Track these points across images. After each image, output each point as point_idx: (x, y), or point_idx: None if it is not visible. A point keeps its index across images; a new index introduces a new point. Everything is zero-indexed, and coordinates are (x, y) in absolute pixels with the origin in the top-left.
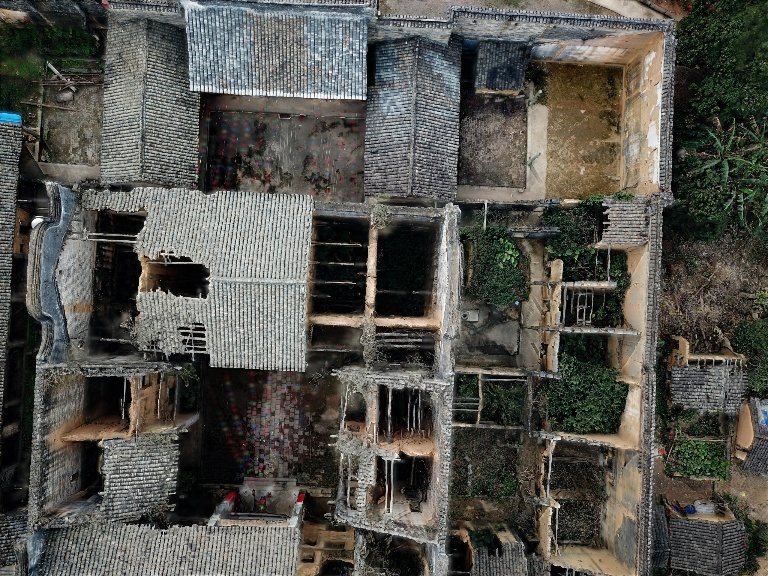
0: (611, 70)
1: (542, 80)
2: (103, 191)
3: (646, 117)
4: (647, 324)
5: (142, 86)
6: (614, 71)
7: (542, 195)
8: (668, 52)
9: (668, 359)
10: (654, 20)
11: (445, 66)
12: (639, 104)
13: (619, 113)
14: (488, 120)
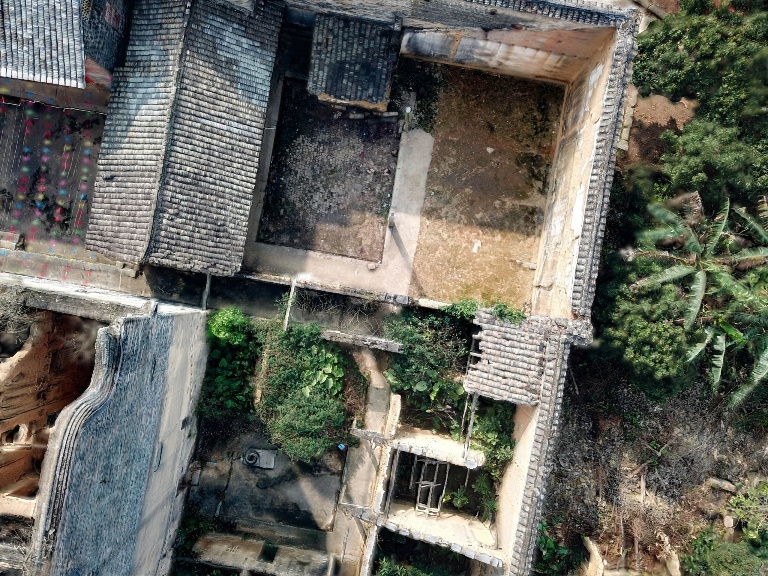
0: (545, 89)
1: (430, 92)
2: None
3: (577, 176)
4: (512, 557)
5: None
6: (550, 91)
7: (405, 278)
8: (618, 66)
9: (573, 574)
10: (602, 5)
11: (245, 47)
12: (572, 151)
13: (549, 160)
14: (336, 146)
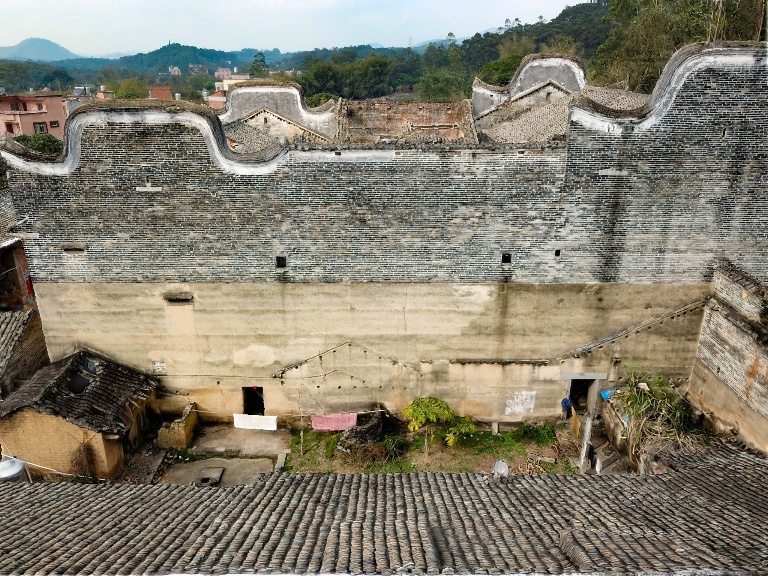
0: None
1: None
2: None
3: None
4: None
5: None
6: None
7: None
8: None
9: None
10: None
11: None
12: None
13: None
14: None
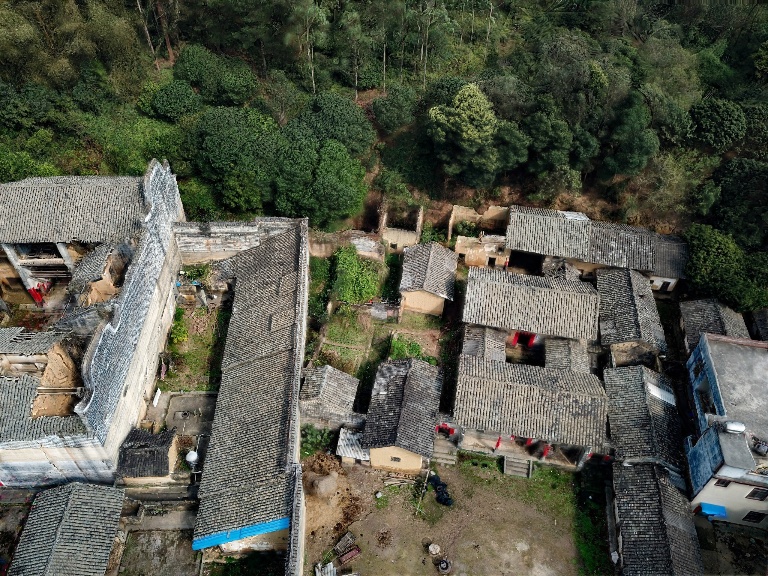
0: None
1: None
2: (67, 434)
3: None
4: None
5: (46, 573)
6: None
7: None
8: None
9: None
10: None
11: None
12: None
13: None
14: None
